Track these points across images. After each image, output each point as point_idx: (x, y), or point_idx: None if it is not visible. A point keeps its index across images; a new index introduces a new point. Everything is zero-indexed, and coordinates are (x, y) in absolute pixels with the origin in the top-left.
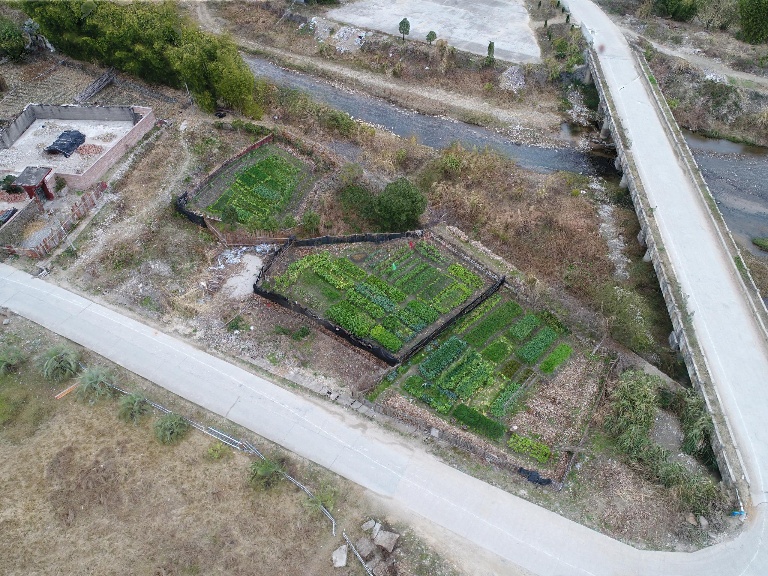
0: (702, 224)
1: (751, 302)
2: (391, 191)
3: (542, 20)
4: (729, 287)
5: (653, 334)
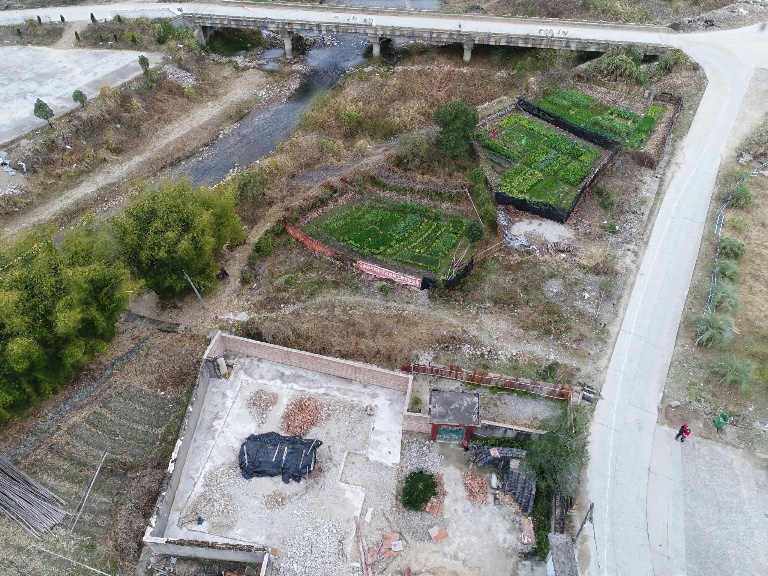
0: (459, 21)
1: (537, 20)
2: (463, 112)
3: (54, 40)
4: (520, 25)
5: (537, 71)
